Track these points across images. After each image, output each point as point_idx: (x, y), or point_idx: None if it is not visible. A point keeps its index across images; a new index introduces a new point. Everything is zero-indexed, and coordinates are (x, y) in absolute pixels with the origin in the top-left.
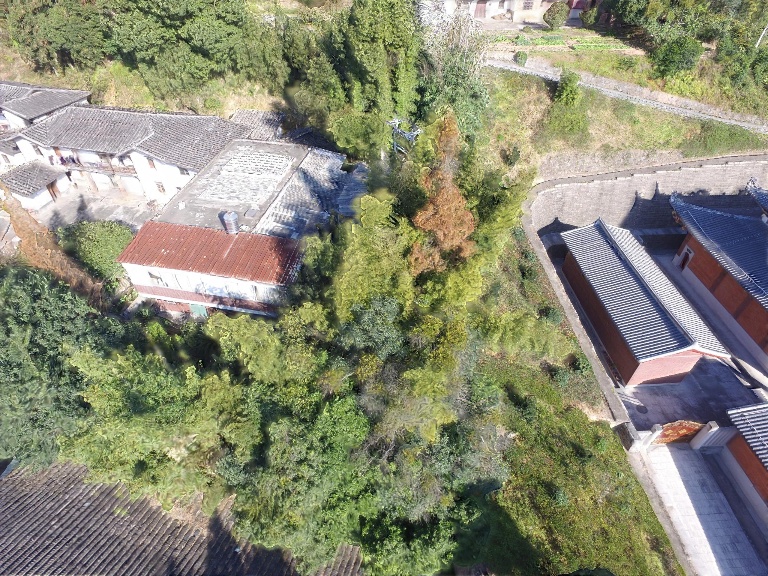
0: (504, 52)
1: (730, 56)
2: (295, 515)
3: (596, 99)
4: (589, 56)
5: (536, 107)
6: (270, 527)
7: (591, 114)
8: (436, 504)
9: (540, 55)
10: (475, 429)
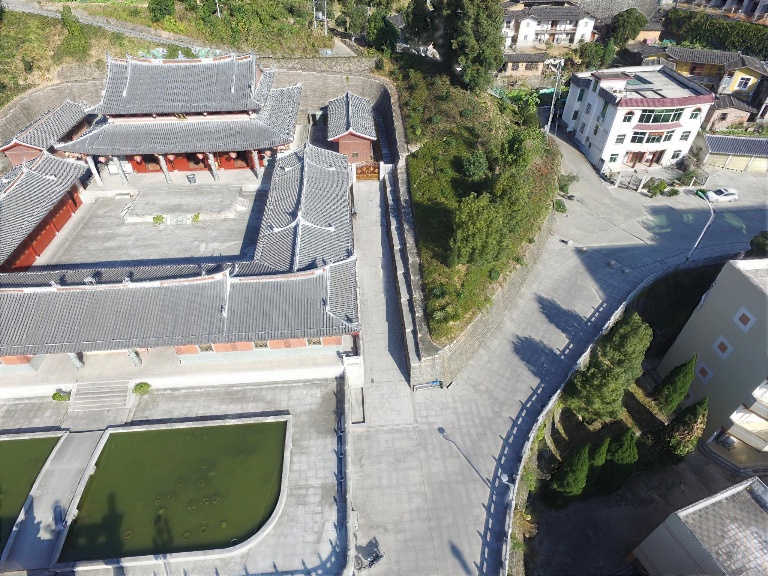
0: (58, 6)
1: (190, 6)
2: None
3: (100, 33)
4: (110, 8)
5: (59, 38)
6: None
7: (95, 42)
8: None
9: (80, 8)
10: None
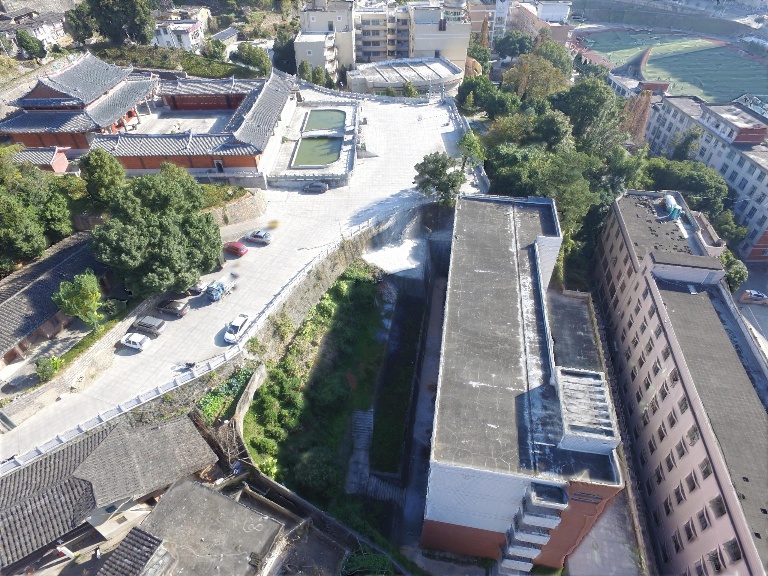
0: None
1: None
2: (17, 208)
3: None
4: None
5: None
6: (17, 221)
7: None
8: (45, 192)
9: None
10: (28, 167)
